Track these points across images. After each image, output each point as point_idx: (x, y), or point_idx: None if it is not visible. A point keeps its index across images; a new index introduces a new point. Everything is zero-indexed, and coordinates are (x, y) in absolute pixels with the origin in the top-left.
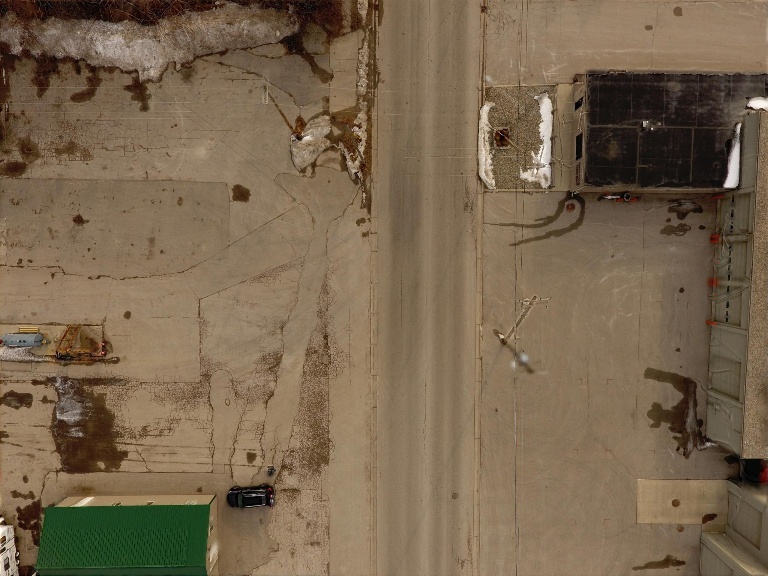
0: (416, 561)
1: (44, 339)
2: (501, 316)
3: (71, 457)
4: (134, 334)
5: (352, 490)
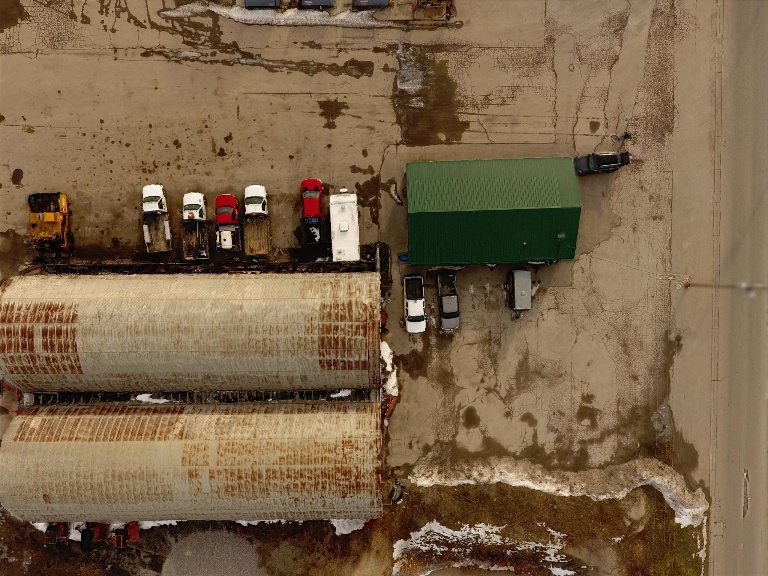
0: (760, 234)
1: None
2: None
3: (411, 129)
4: None
5: (696, 160)
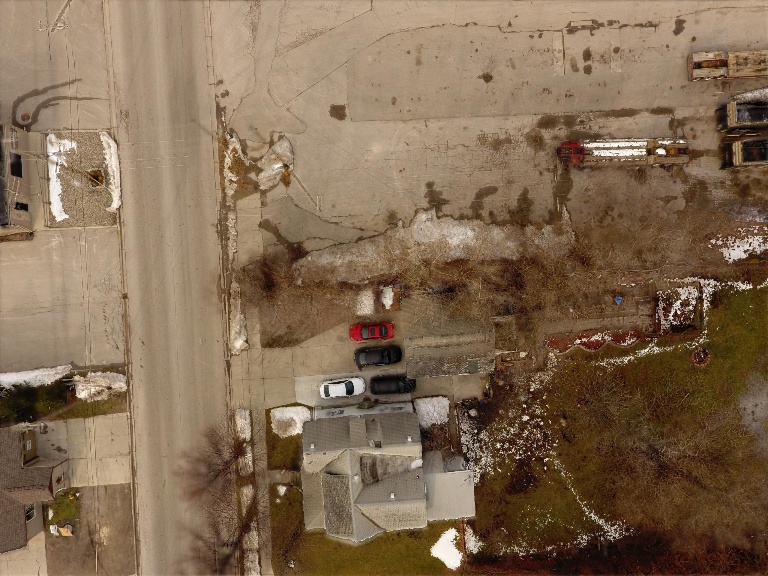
0: None
1: None
2: (84, 12)
3: None
4: None
5: None
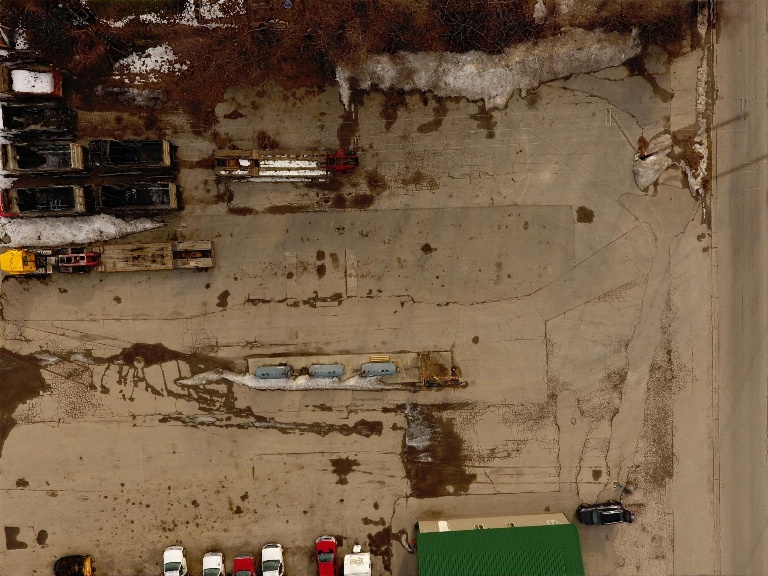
0: (760, 570)
1: (399, 367)
2: None
3: (420, 482)
4: (482, 358)
5: (695, 502)
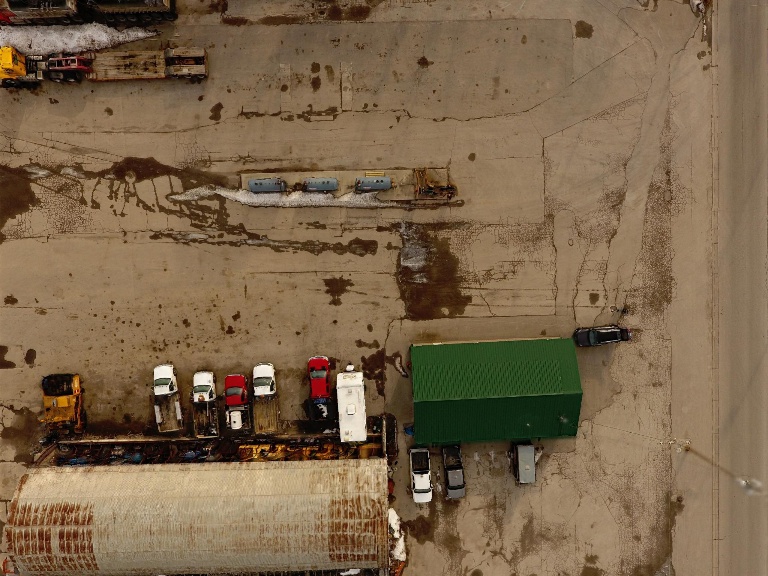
0: (758, 399)
1: (394, 182)
2: None
3: (415, 304)
4: (479, 176)
5: (694, 328)
